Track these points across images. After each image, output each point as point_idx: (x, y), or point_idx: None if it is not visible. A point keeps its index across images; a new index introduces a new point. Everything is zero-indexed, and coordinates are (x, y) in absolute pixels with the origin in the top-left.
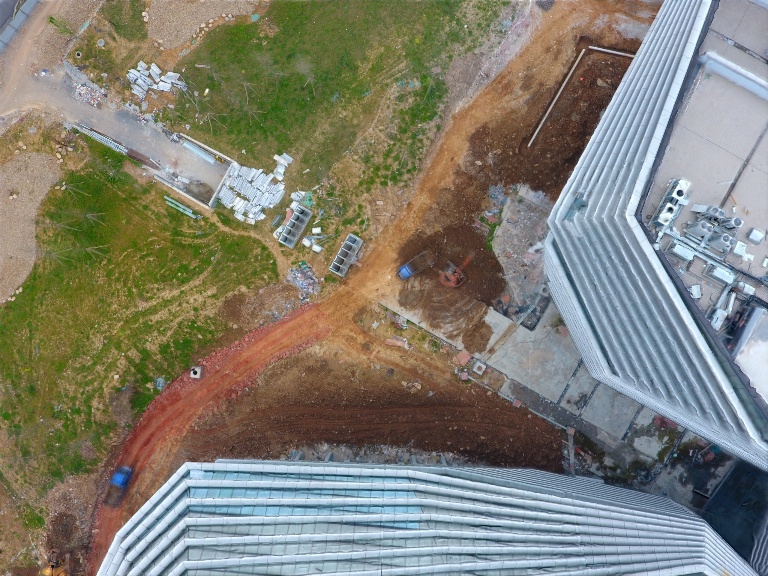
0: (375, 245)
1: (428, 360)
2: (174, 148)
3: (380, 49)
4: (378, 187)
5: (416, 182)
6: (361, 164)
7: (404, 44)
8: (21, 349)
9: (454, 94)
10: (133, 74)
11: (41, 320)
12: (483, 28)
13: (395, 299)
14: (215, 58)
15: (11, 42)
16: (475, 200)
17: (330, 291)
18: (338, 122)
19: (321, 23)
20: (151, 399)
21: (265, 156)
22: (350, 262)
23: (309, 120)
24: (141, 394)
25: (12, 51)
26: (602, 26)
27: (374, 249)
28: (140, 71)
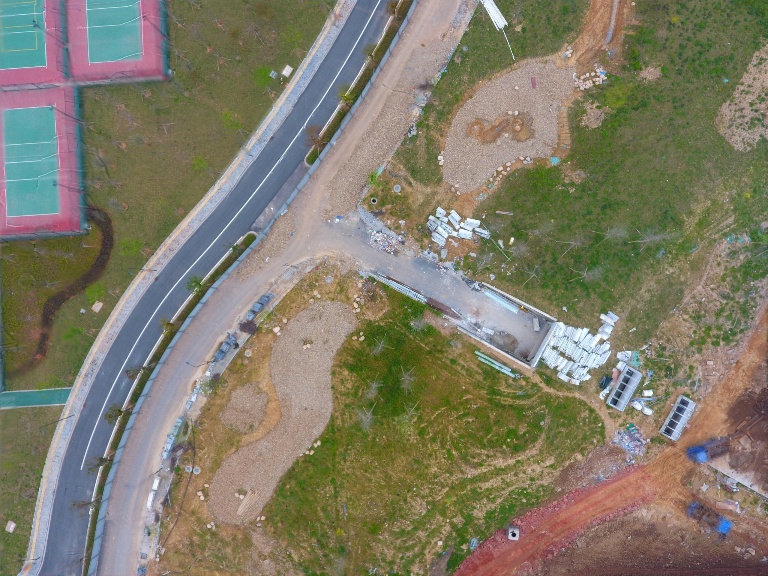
0: (703, 405)
1: (761, 524)
2: (475, 297)
3: (706, 203)
4: (710, 347)
5: (745, 340)
6: (692, 323)
7: (732, 198)
8: (326, 507)
9: None
10: (433, 222)
11: (346, 477)
12: None
13: (725, 461)
14: (518, 205)
15: (303, 188)
16: None
17: (656, 452)
18: (665, 279)
19: (636, 172)
20: (463, 559)
21: (588, 314)
22: (684, 426)
23: (634, 277)
24: (453, 554)
25: (304, 197)
26: None
27: (703, 409)
28: (440, 218)
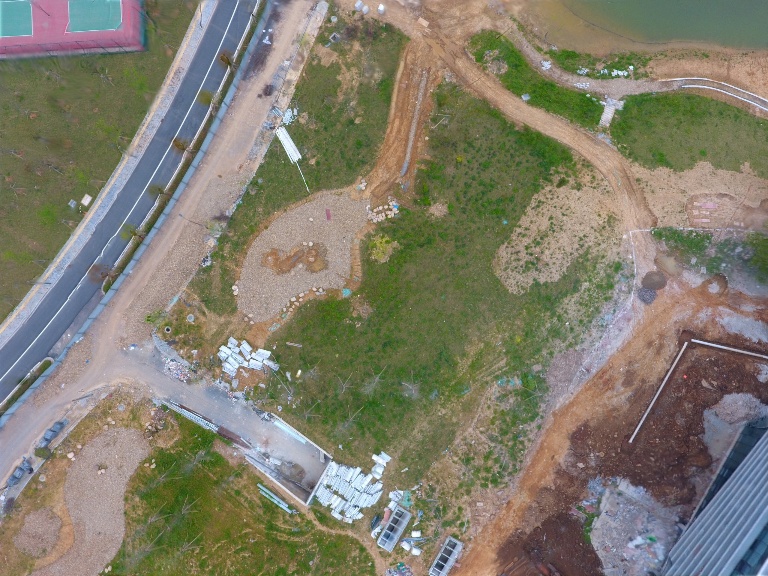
0: (474, 545)
1: None
2: (265, 426)
3: (480, 345)
4: (478, 489)
5: (516, 481)
6: (461, 466)
7: (504, 341)
8: None
9: (555, 392)
10: (224, 352)
11: None
12: (585, 324)
13: None
14: (307, 337)
15: (100, 315)
16: (574, 494)
17: None
18: (437, 420)
19: (417, 310)
20: None
21: (363, 453)
22: (450, 568)
23: (407, 417)
24: None
25: (101, 324)
26: (705, 320)
27: (473, 549)
28: (231, 349)
